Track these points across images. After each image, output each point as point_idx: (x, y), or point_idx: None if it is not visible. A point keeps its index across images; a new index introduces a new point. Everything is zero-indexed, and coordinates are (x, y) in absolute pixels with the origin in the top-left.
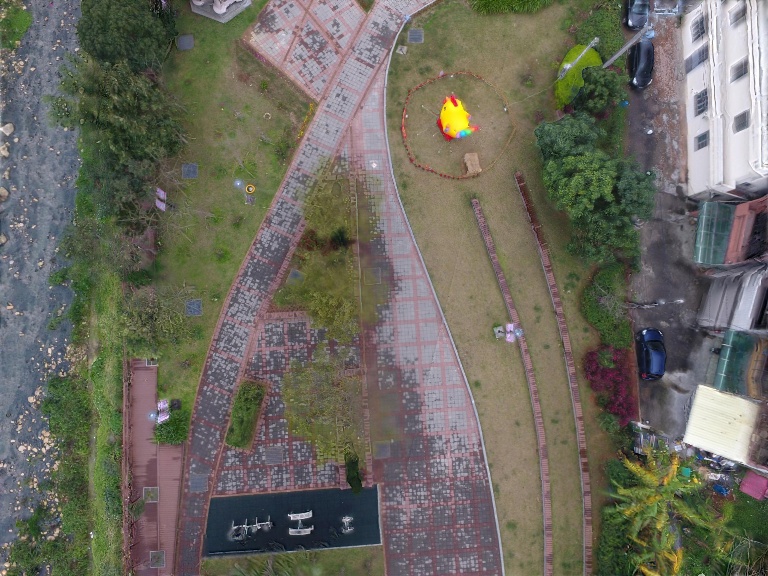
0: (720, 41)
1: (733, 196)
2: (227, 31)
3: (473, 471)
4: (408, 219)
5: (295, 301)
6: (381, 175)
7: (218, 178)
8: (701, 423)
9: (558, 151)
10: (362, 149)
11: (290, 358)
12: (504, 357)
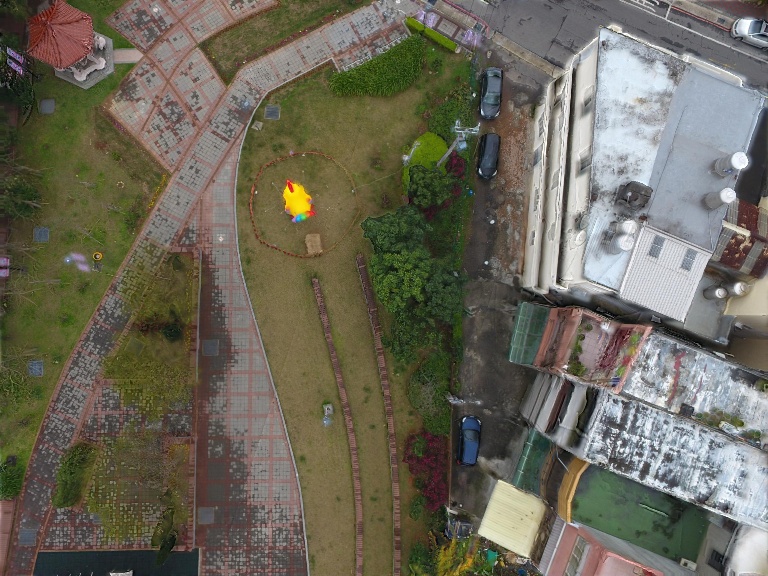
0: (550, 145)
1: (546, 300)
2: (88, 97)
3: (292, 541)
4: (249, 294)
5: (132, 369)
6: (227, 249)
7: (68, 244)
8: (496, 517)
9: (379, 246)
10: (211, 222)
11: (124, 423)
12: (331, 434)
